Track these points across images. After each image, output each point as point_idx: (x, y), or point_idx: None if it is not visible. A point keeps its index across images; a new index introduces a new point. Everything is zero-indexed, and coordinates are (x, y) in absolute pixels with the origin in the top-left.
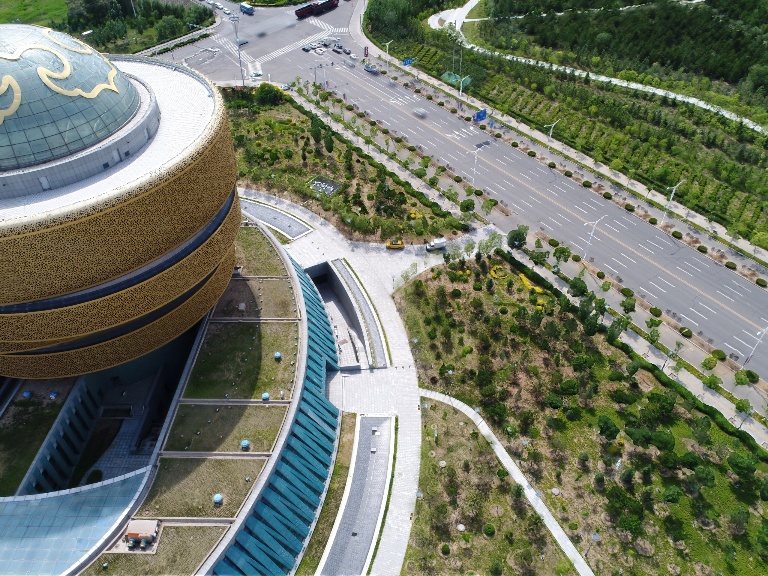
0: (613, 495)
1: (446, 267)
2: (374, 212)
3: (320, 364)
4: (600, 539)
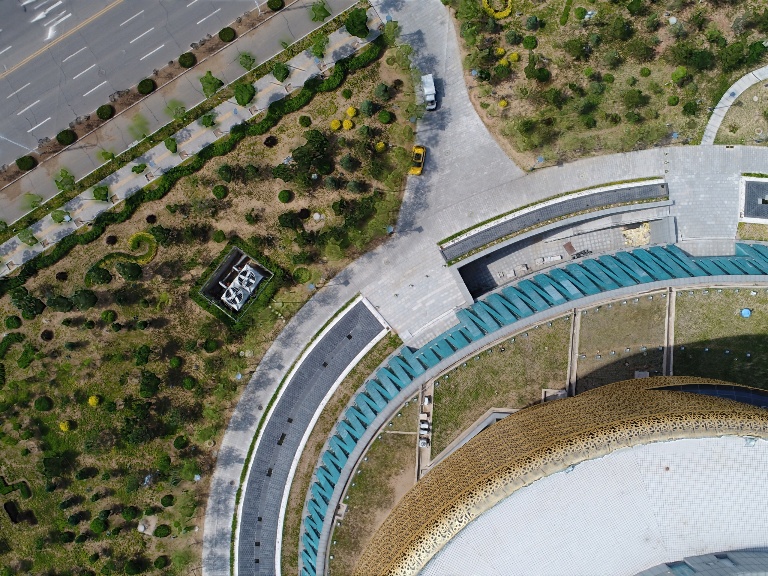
0: None
1: (479, 84)
2: (329, 191)
3: (712, 263)
4: None
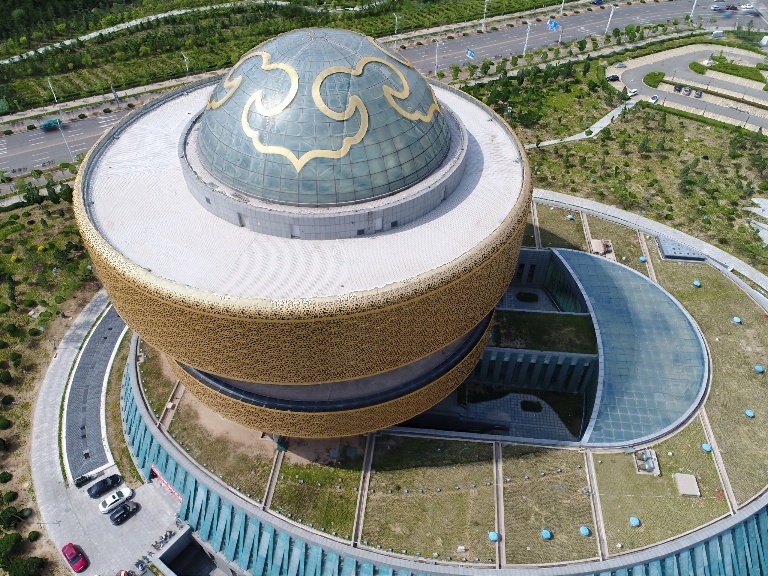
0: (524, 118)
1: None
2: None
3: None
4: (540, 134)
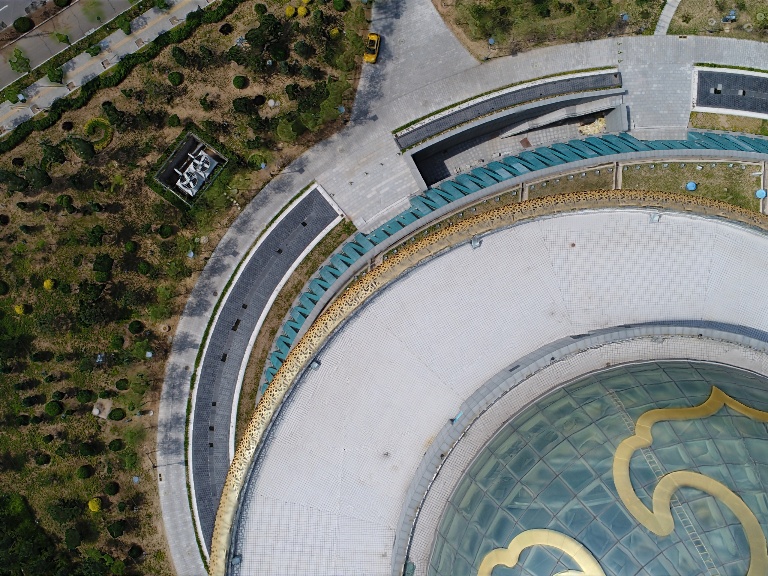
0: None
1: None
2: (284, 78)
3: None
4: None
